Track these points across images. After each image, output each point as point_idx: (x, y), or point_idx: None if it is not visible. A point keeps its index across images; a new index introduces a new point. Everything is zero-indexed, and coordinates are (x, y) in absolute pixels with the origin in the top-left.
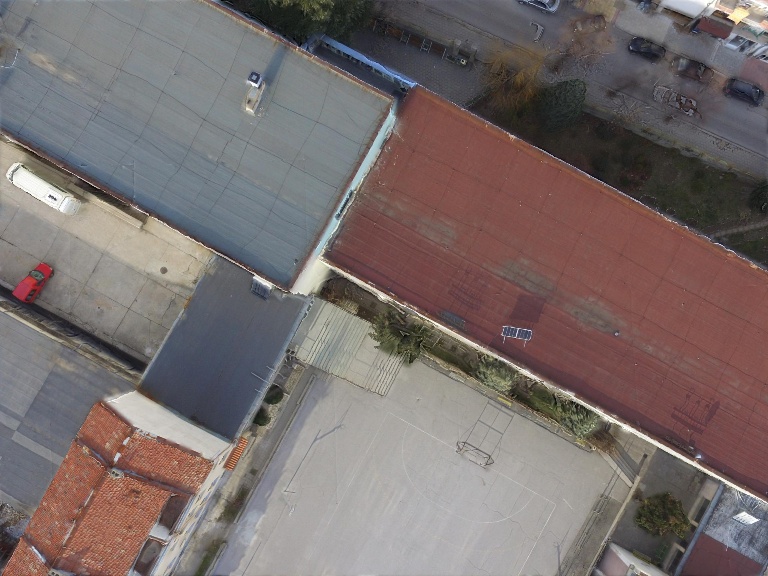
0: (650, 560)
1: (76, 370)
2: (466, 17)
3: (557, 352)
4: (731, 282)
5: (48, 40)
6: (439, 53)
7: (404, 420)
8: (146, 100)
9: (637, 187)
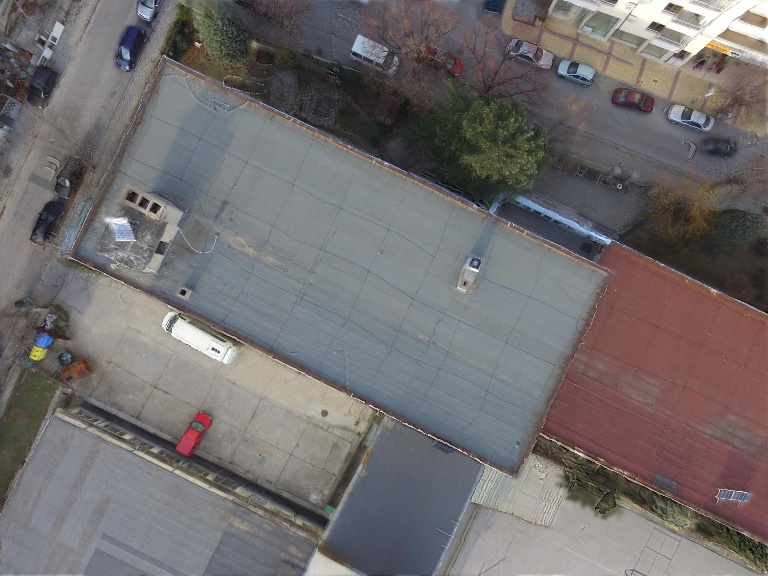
0: None
1: (250, 529)
2: (618, 139)
3: None
4: None
5: (248, 223)
6: (594, 178)
7: (569, 550)
8: (352, 281)
9: None
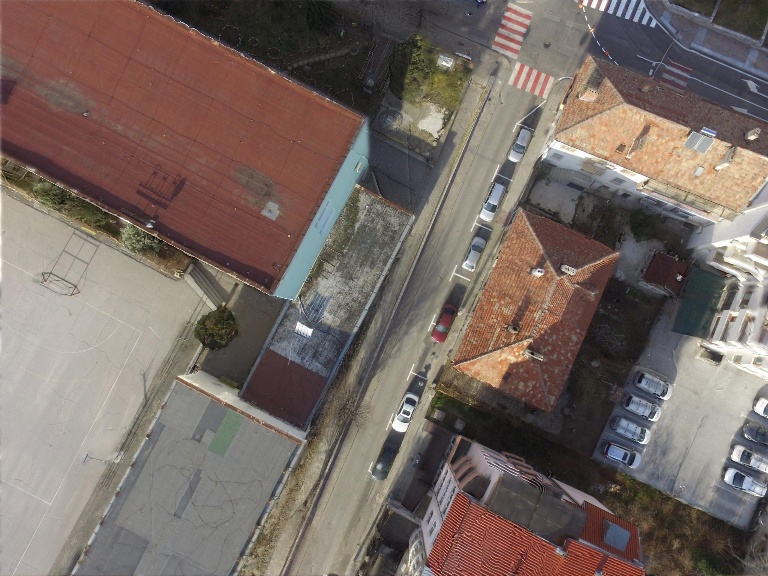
0: (236, 385)
1: None
2: None
3: (24, 132)
4: (195, 60)
5: None
6: None
7: None
8: None
9: (217, 17)
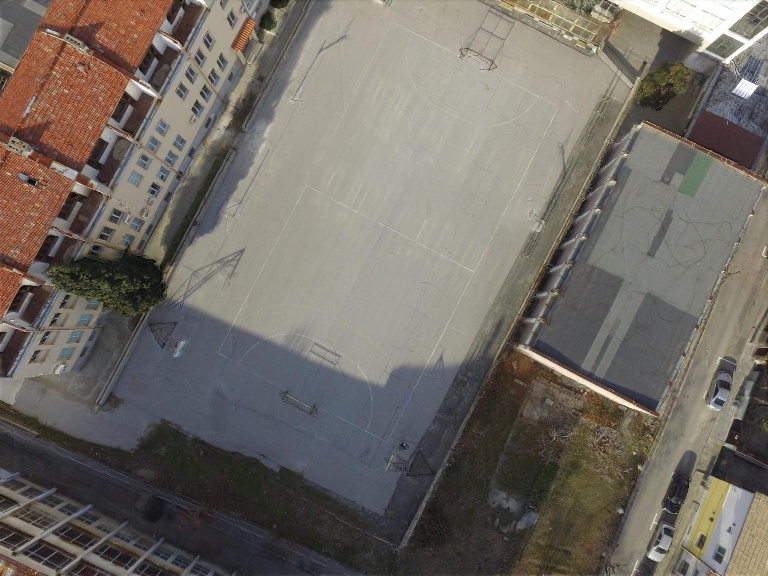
0: None
1: None
2: None
3: None
4: None
5: None
6: None
7: (408, 29)
8: None
9: None
